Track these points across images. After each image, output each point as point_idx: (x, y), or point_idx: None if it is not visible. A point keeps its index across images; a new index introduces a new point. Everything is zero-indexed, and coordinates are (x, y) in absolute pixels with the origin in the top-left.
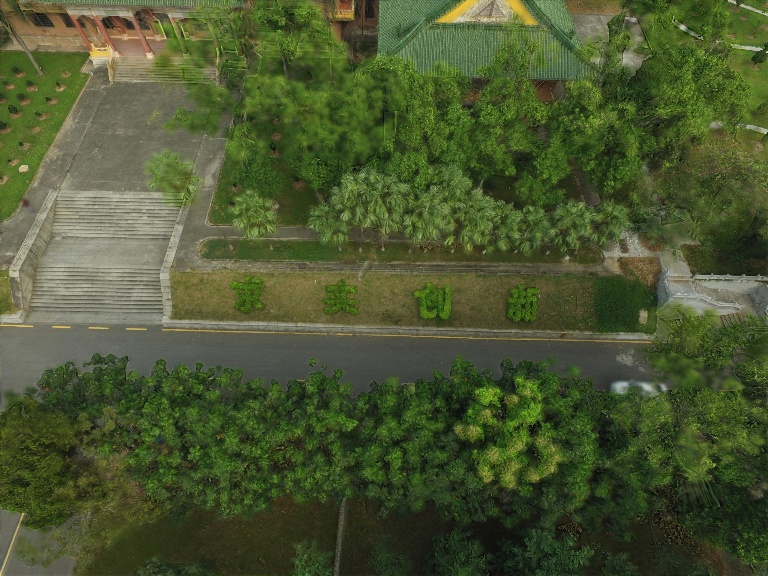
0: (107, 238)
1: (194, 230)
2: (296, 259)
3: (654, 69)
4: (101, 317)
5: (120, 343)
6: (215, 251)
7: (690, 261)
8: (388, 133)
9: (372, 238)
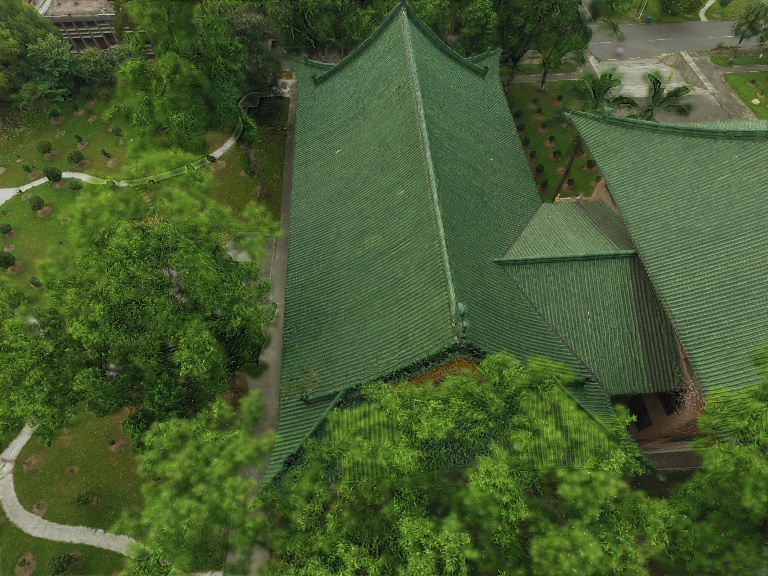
0: (650, 84)
1: (590, 76)
2: (511, 66)
3: (262, 33)
4: (617, 63)
5: (595, 55)
6: (567, 66)
7: None
8: None
9: None
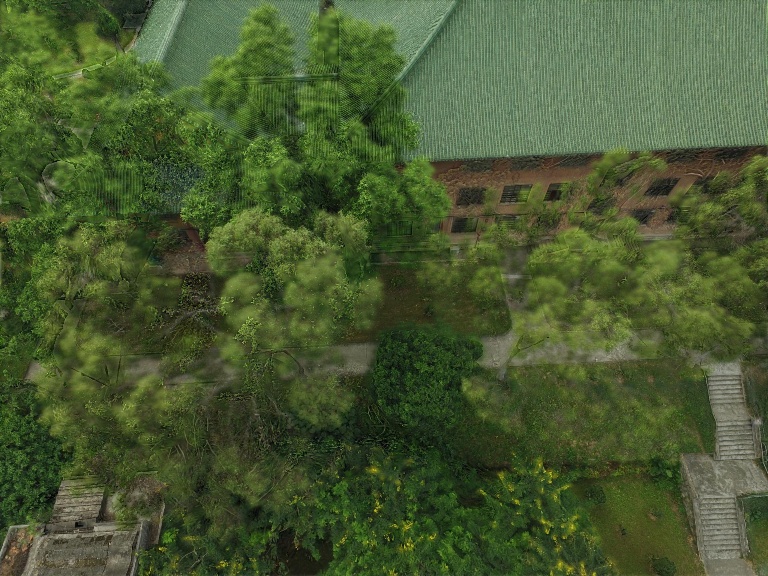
0: None
1: None
2: None
3: None
4: None
5: None
6: None
7: (145, 7)
8: (320, 60)
9: (332, 8)
